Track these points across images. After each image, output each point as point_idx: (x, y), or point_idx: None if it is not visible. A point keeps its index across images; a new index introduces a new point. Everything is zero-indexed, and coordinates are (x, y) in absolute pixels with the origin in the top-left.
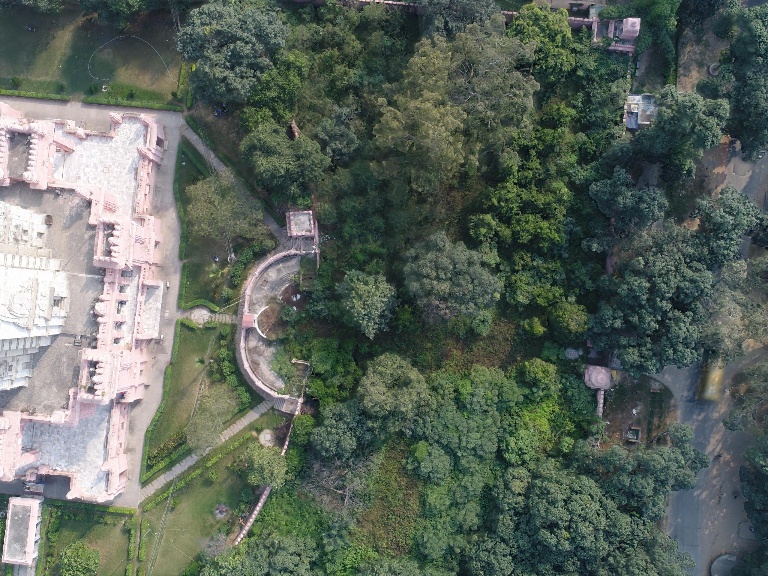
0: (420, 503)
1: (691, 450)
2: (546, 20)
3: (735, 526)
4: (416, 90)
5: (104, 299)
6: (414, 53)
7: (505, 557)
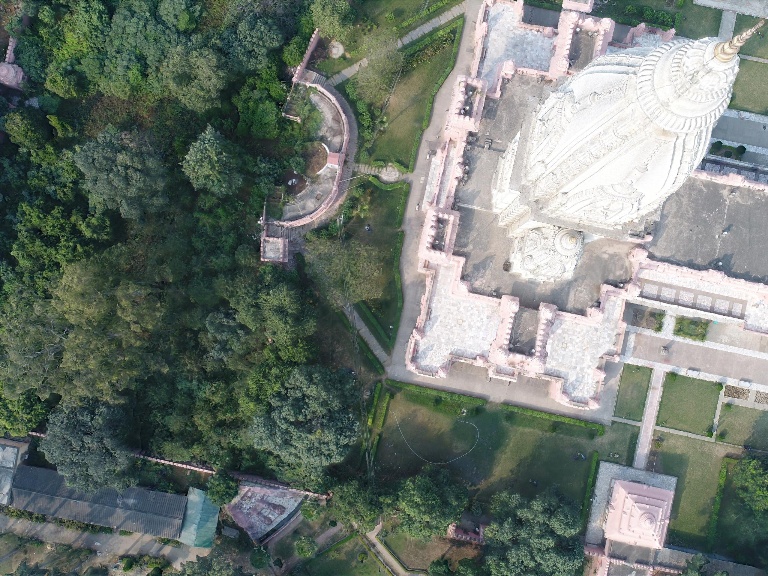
0: None
1: None
2: (1, 415)
3: None
4: (116, 346)
5: None
6: (146, 407)
7: None
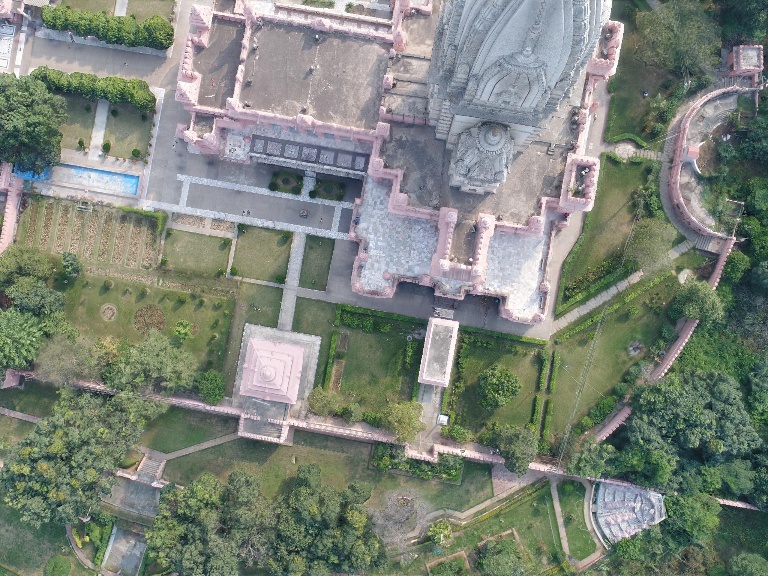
0: None
1: None
2: None
3: None
4: None
5: (588, 106)
6: None
7: None
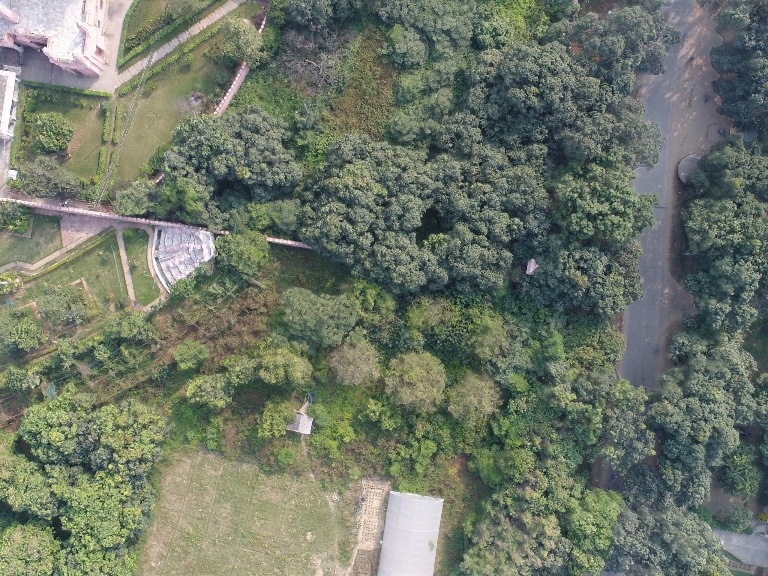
0: (393, 93)
1: (663, 20)
2: None
3: (704, 129)
4: None
5: None
6: None
7: (474, 128)
